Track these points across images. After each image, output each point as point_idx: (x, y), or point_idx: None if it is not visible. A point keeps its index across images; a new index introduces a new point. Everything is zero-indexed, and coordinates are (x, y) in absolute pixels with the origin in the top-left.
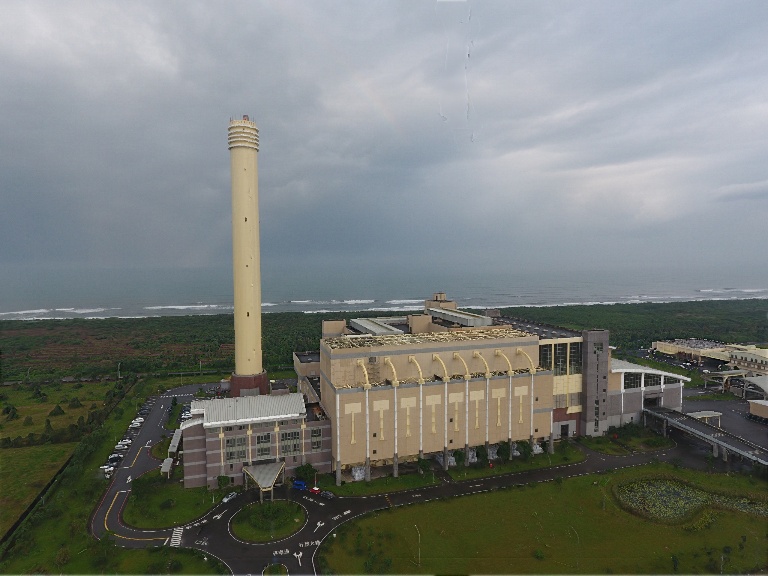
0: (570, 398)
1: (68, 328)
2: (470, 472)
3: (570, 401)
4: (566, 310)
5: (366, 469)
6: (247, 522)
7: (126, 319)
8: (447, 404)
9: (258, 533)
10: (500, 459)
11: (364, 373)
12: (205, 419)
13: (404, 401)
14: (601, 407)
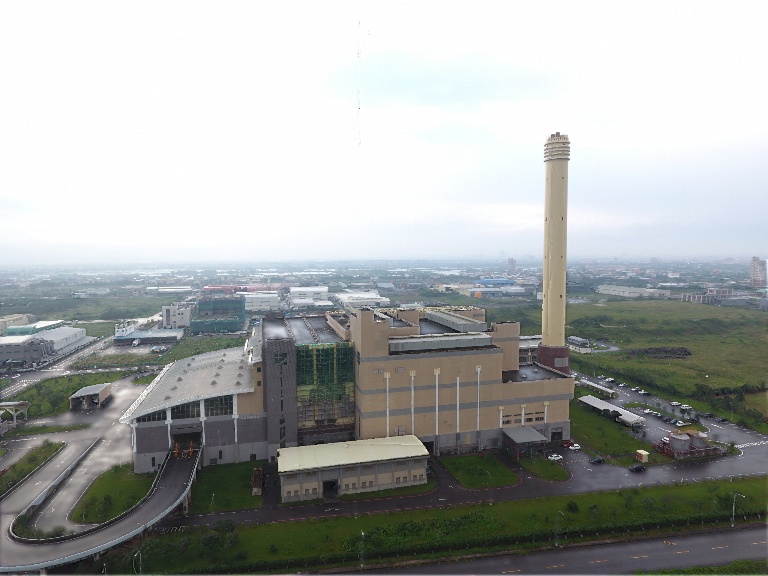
0: None
1: None
2: None
3: None
4: None
5: None
6: None
7: None
8: None
9: None
10: None
11: None
12: None
13: None
14: None
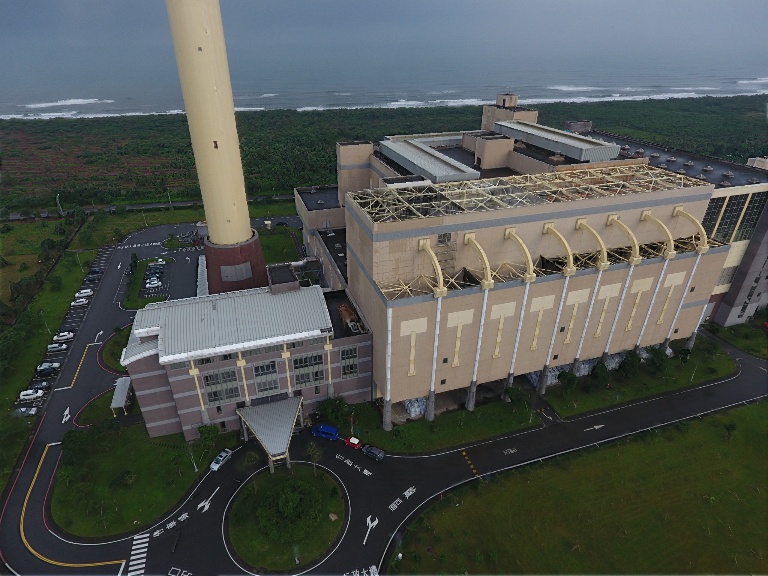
0: (720, 275)
1: (4, 132)
2: (579, 399)
3: (719, 279)
4: (614, 107)
5: (429, 405)
6: (253, 522)
7: (76, 120)
8: (562, 307)
9: (273, 550)
10: (616, 371)
11: (435, 268)
12: (161, 349)
13: (497, 309)
14: (759, 286)
